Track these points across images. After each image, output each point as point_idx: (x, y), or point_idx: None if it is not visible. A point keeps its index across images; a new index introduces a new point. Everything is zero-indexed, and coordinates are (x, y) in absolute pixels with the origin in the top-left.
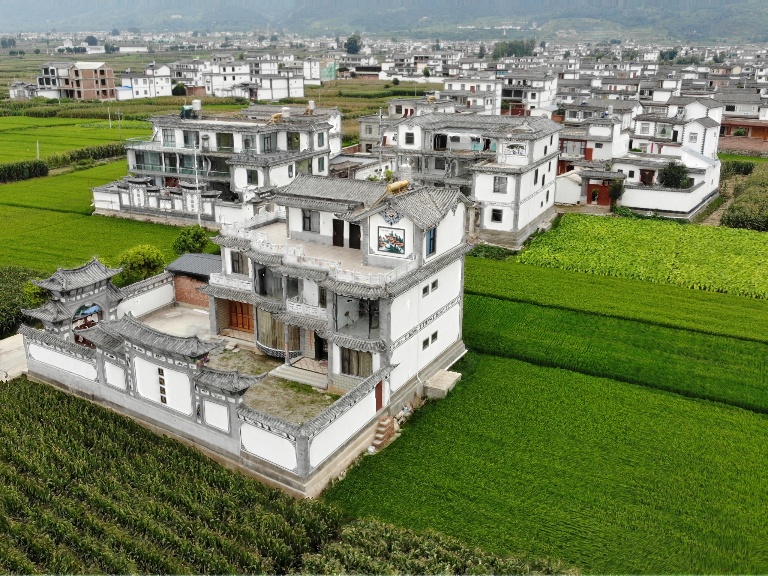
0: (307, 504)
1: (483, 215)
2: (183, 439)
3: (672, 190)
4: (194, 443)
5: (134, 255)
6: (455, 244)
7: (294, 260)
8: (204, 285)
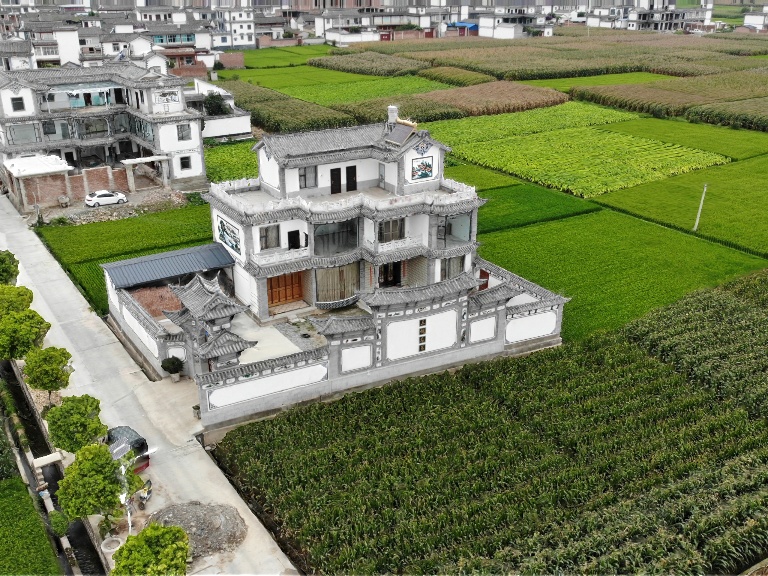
0: (599, 336)
1: (172, 166)
2: (443, 372)
3: (236, 116)
4: (456, 368)
5: (19, 298)
6: None
7: (386, 204)
8: None
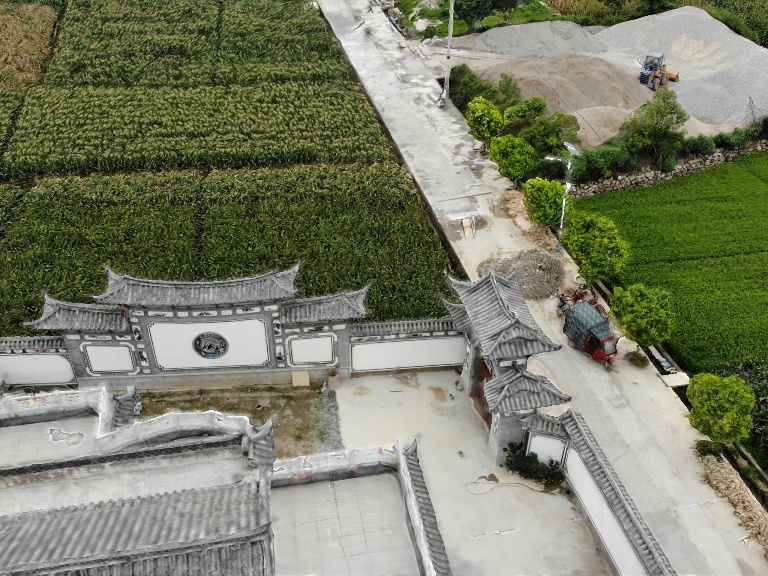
0: None
1: None
2: None
3: None
4: None
5: None
6: None
7: None
8: None
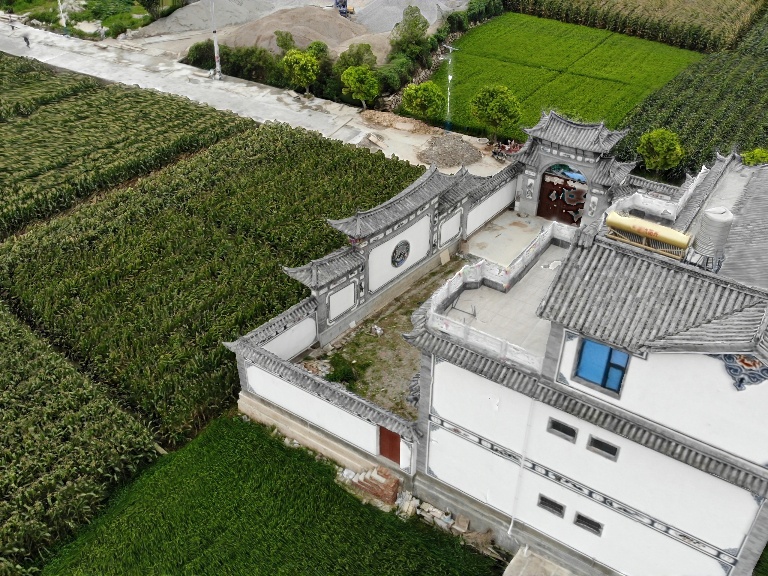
0: None
1: None
2: None
3: None
4: None
5: None
6: (734, 449)
7: None
8: None
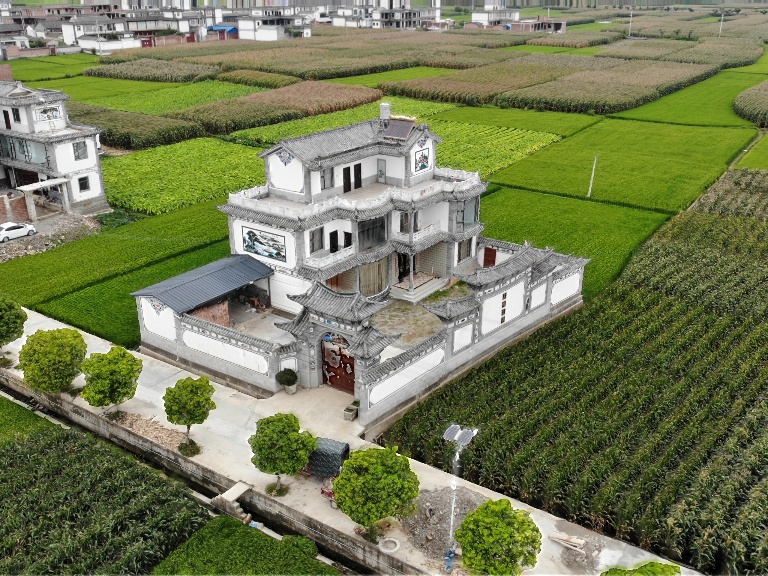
0: None
1: (71, 188)
2: (515, 339)
3: None
4: (522, 334)
5: (77, 340)
6: None
7: (418, 195)
8: (222, 306)
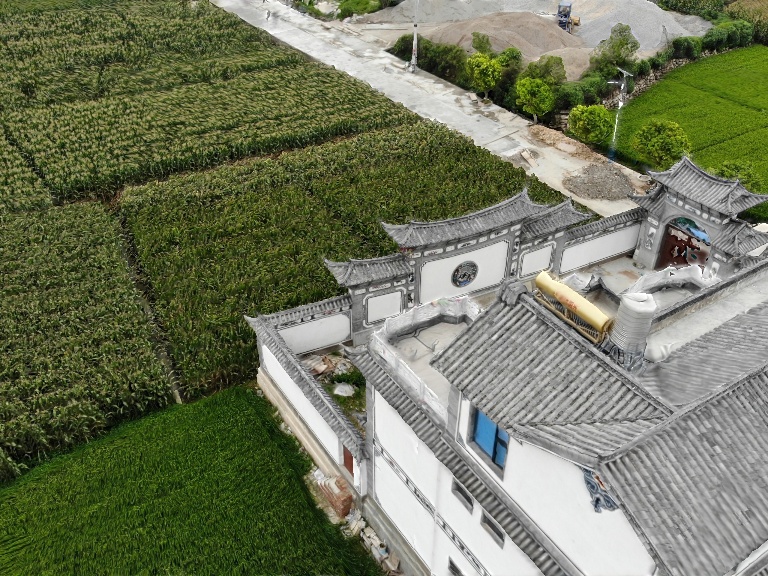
0: None
1: None
2: None
3: None
4: None
5: None
6: None
7: None
8: None
